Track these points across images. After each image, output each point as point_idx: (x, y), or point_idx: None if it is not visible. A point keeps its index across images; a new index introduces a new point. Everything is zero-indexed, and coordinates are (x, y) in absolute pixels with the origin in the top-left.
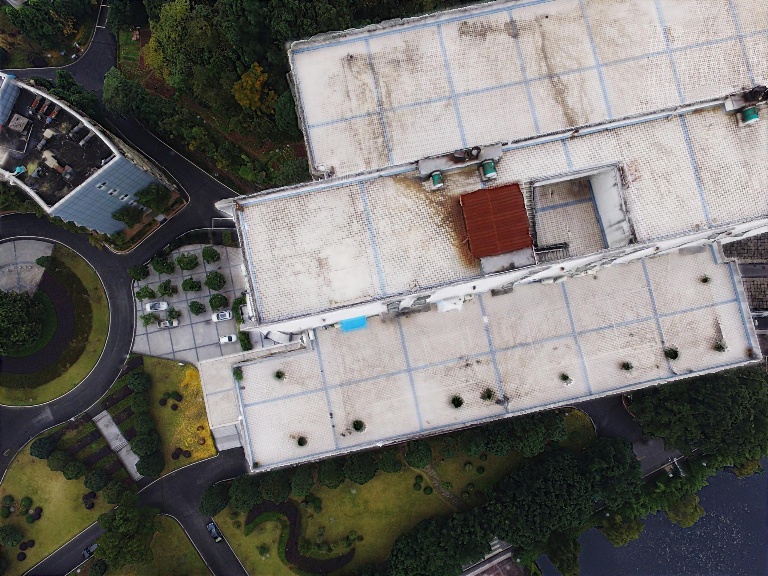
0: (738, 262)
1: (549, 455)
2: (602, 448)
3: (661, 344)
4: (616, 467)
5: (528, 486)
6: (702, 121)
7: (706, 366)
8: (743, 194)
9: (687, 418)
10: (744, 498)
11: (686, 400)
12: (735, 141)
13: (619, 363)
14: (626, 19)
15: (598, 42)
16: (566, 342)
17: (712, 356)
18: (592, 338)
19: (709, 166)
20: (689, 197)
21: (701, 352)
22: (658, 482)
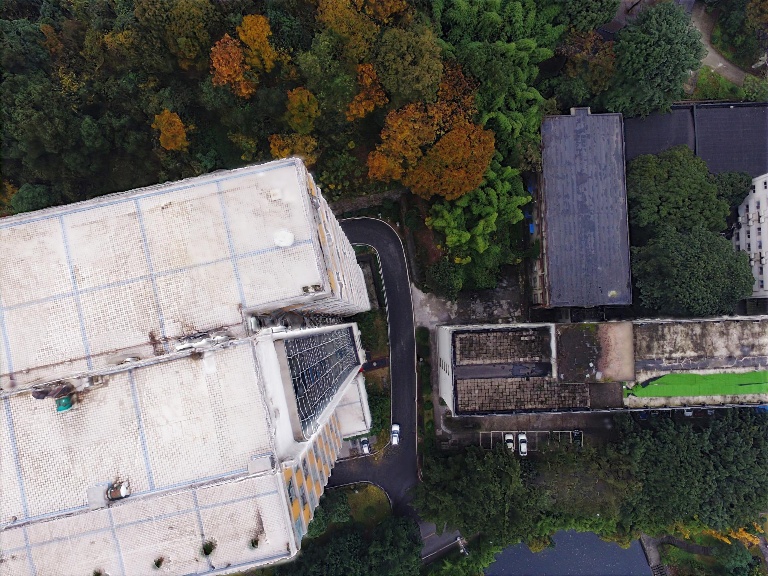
0: (476, 363)
1: (335, 534)
2: (385, 529)
3: (201, 537)
4: (390, 551)
5: (307, 569)
6: (27, 404)
7: (245, 559)
8: (65, 483)
9: (450, 507)
10: (543, 568)
11: (452, 488)
12: (60, 426)
13: (156, 557)
14: (33, 258)
15: (3, 283)
16: (104, 536)
17: (251, 549)
18: (130, 531)
19: (31, 453)
20: (8, 487)
21: (240, 545)
22: (445, 559)
